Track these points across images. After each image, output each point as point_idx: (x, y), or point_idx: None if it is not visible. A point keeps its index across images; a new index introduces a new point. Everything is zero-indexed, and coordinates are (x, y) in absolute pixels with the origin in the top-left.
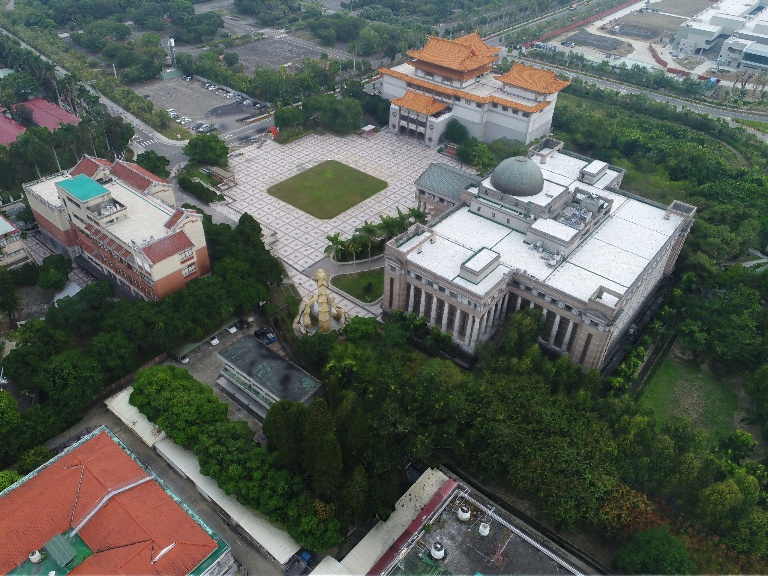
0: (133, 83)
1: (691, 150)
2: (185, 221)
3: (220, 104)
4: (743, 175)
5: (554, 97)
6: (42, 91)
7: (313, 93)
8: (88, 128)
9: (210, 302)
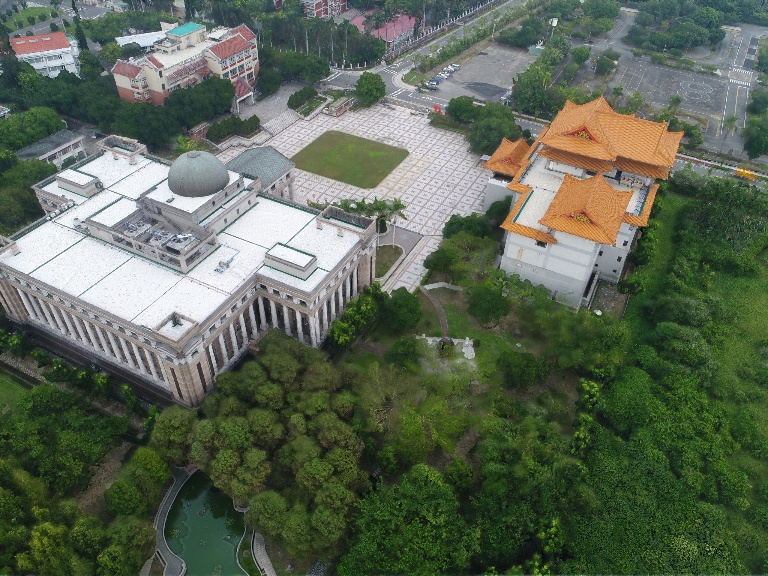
0: (504, 43)
1: (532, 447)
2: (145, 63)
3: (497, 84)
4: (531, 574)
5: (586, 248)
6: (429, 15)
7: (554, 116)
8: (330, 29)
9: (106, 111)
